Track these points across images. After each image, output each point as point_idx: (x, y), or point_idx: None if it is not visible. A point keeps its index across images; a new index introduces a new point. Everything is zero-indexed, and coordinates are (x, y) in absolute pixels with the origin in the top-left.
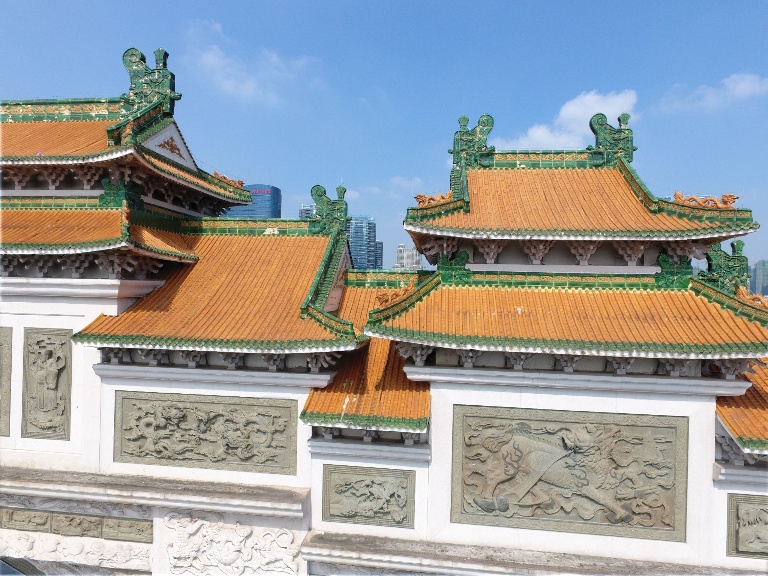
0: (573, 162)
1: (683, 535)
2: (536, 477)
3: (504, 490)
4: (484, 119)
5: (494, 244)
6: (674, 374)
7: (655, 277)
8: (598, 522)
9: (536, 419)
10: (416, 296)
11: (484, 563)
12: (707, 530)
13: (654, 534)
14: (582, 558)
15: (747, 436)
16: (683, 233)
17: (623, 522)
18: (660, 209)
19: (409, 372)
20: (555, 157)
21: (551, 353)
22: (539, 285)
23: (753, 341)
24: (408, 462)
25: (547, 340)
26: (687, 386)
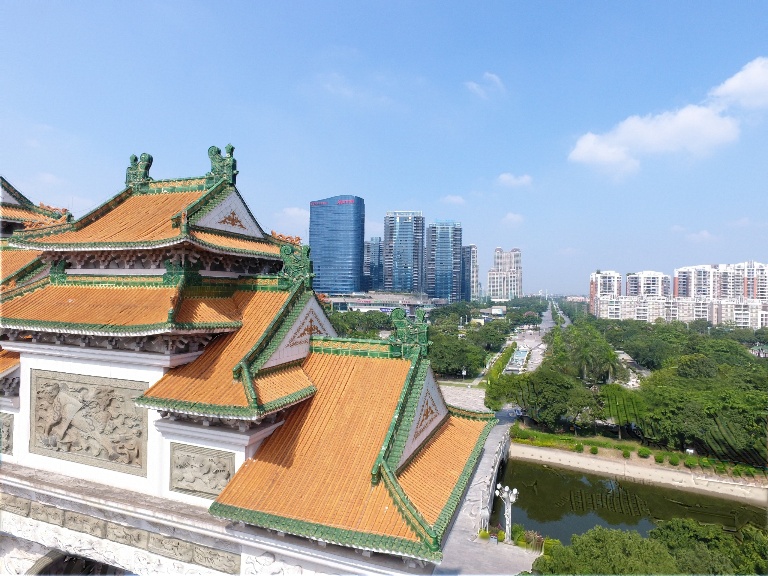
0: (195, 186)
1: (146, 472)
2: (68, 422)
3: (56, 431)
4: (142, 157)
5: (74, 254)
6: (136, 349)
7: (162, 277)
8: (102, 458)
9: (71, 381)
10: (16, 292)
11: (21, 478)
12: (158, 469)
13: (131, 470)
14: (88, 483)
15: (147, 395)
16: (150, 243)
17: (114, 459)
18: (179, 224)
19: (1, 345)
20: (185, 183)
21: (45, 331)
22: (100, 284)
23: (148, 324)
24: (10, 408)
25: (48, 322)
26: (137, 358)
